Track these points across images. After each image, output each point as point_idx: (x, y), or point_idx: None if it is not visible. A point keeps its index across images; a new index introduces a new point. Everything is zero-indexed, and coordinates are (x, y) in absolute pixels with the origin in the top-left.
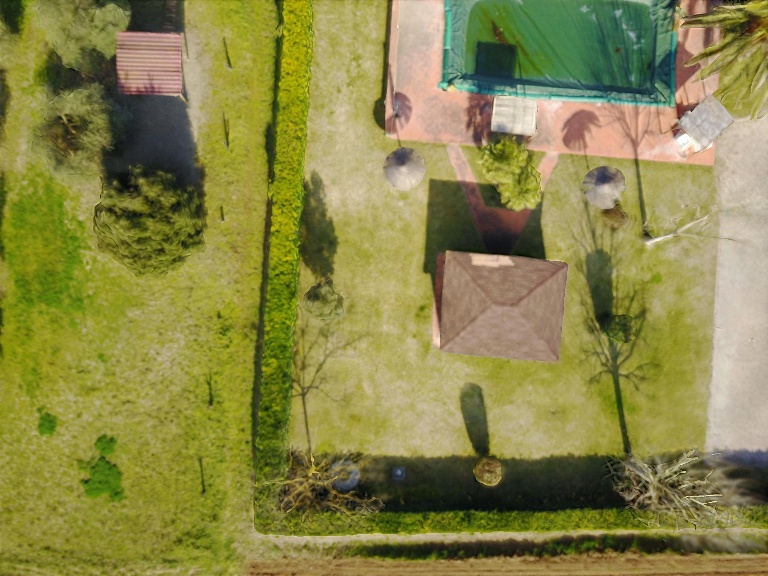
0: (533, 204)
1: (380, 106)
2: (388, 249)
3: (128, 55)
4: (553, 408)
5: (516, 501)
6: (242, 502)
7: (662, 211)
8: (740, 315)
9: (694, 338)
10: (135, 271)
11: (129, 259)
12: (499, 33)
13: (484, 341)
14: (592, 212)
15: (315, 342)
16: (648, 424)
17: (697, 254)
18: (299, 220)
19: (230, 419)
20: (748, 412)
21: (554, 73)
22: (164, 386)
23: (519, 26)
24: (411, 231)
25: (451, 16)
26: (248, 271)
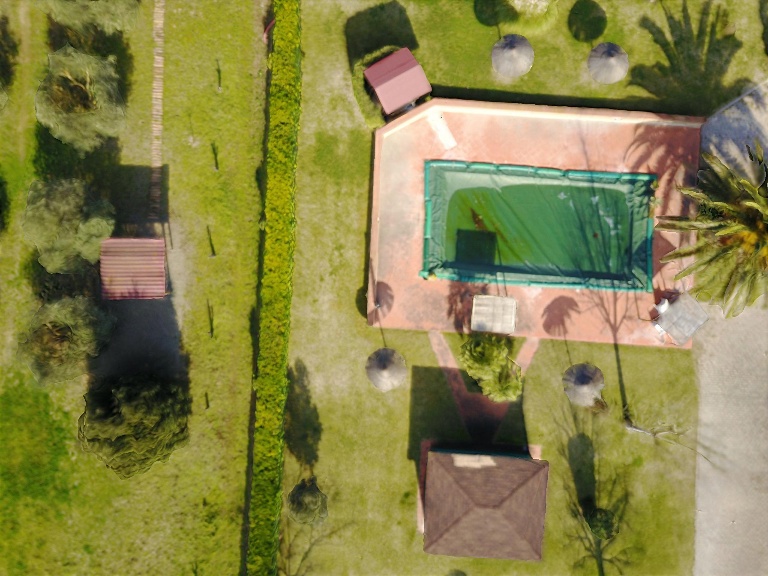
0: None
1: (362, 295)
2: (372, 436)
3: (112, 262)
4: None
5: None
6: None
7: (642, 394)
8: (721, 497)
9: (676, 521)
10: (120, 475)
11: (113, 469)
12: (478, 220)
13: (467, 542)
14: None
15: (300, 530)
16: None
17: None
18: (283, 411)
19: None
20: None
21: (533, 259)
22: (150, 575)
23: (498, 214)
24: (394, 418)
25: (431, 206)
26: (233, 454)
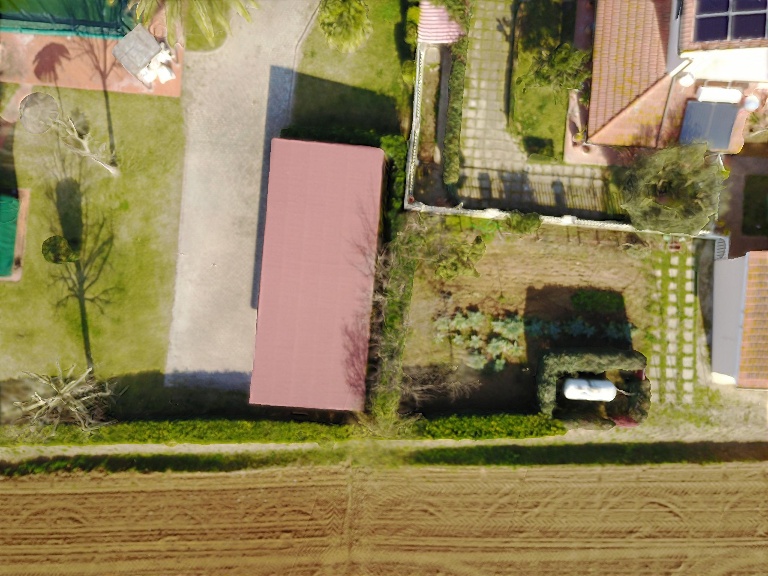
0: None
1: None
2: None
3: None
4: (22, 331)
5: None
6: None
7: (130, 141)
8: (203, 241)
9: (159, 264)
10: None
11: None
12: None
13: None
14: (62, 142)
15: None
16: (112, 347)
17: (164, 183)
18: None
19: None
20: (209, 335)
21: (28, 8)
22: None
23: None
24: None
25: None
26: None
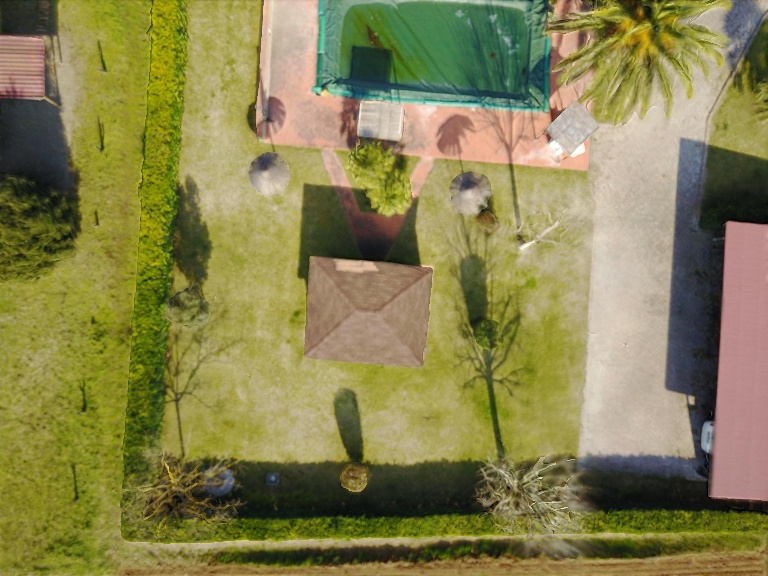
0: (403, 209)
1: (254, 110)
2: (262, 254)
3: None
4: (427, 413)
5: (389, 507)
6: (117, 509)
7: (537, 216)
8: (614, 320)
9: (568, 343)
10: None
11: None
12: (374, 38)
13: (348, 347)
14: (467, 217)
15: (188, 348)
16: (522, 429)
17: (571, 259)
18: (170, 225)
19: (104, 425)
20: (621, 417)
21: (429, 78)
22: (36, 392)
23: (394, 31)
24: (285, 236)
25: (325, 20)
26: (125, 276)
